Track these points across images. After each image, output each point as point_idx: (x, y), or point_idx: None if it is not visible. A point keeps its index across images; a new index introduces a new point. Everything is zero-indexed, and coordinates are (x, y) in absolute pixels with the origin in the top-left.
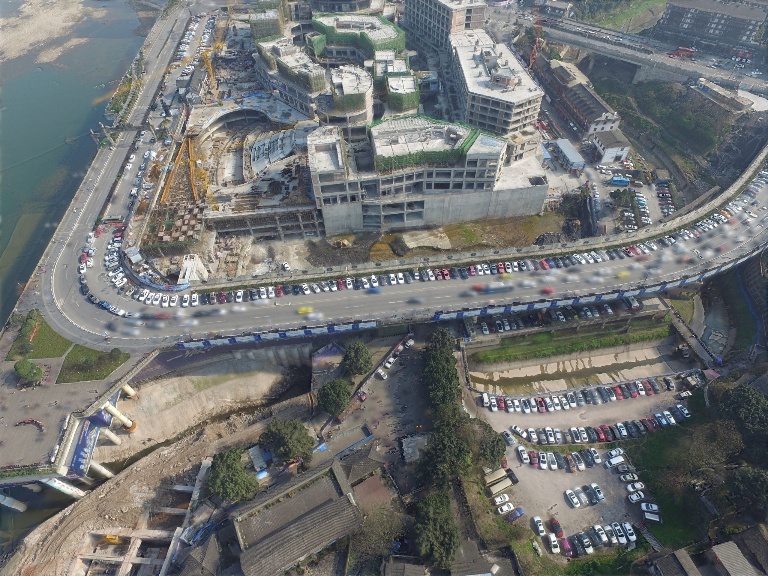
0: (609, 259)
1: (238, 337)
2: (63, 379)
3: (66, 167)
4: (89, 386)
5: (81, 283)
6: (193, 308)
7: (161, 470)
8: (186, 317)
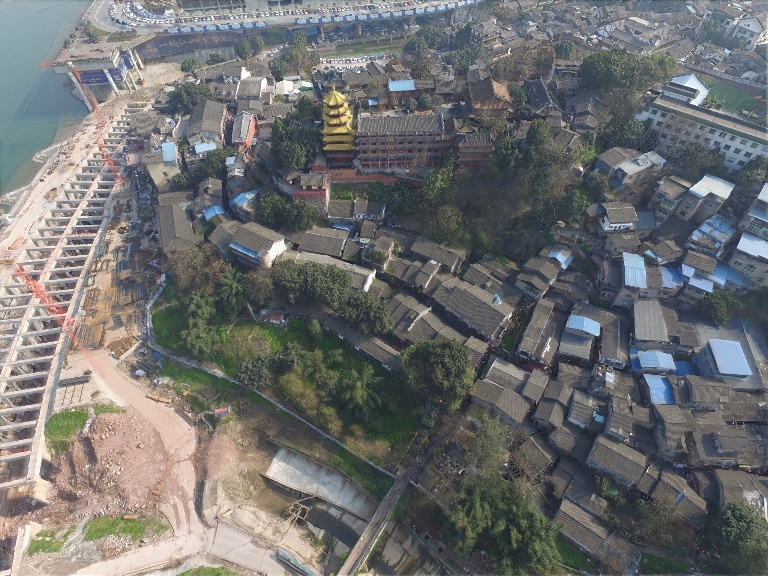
0: (394, 7)
1: (195, 27)
2: (109, 41)
3: (85, 6)
4: (122, 43)
5: (111, 18)
6: (172, 24)
7: (159, 87)
8: (168, 26)
